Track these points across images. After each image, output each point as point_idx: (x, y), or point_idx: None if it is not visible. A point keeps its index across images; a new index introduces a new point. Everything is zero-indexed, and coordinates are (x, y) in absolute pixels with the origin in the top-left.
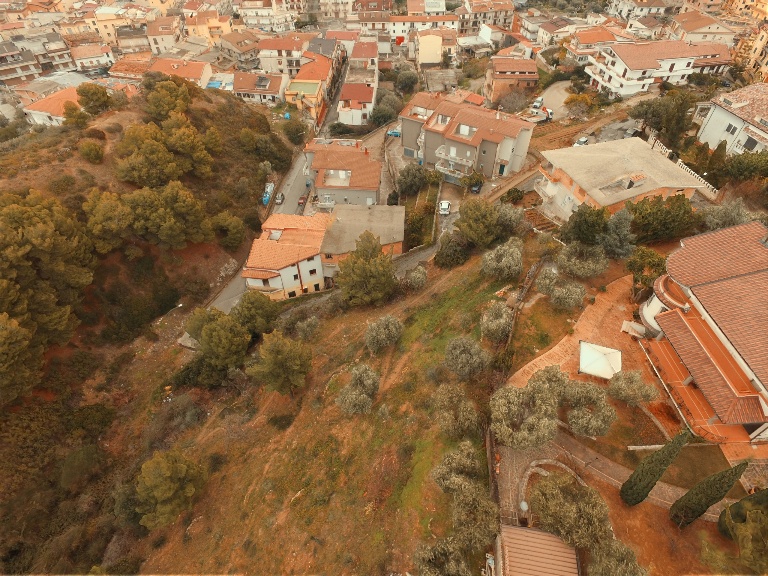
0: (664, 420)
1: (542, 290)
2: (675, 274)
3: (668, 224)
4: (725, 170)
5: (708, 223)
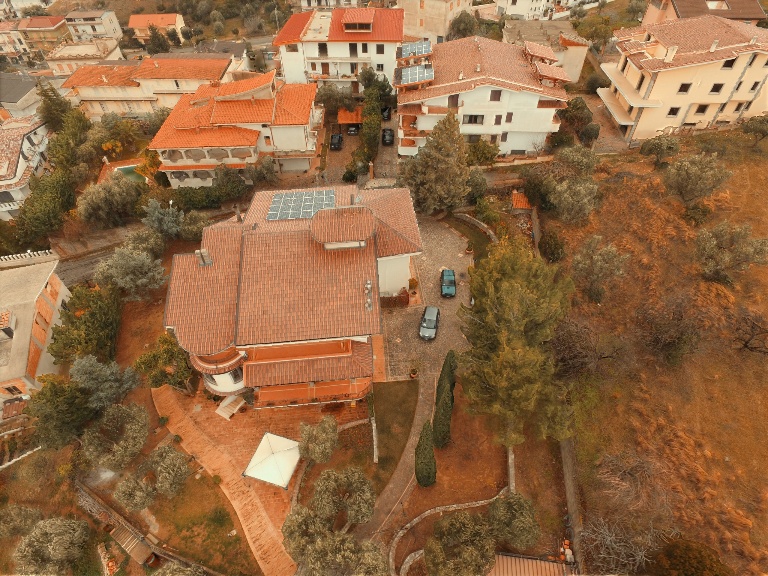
0: (340, 416)
1: (147, 504)
2: (208, 350)
3: (107, 321)
4: (31, 233)
5: (126, 286)
